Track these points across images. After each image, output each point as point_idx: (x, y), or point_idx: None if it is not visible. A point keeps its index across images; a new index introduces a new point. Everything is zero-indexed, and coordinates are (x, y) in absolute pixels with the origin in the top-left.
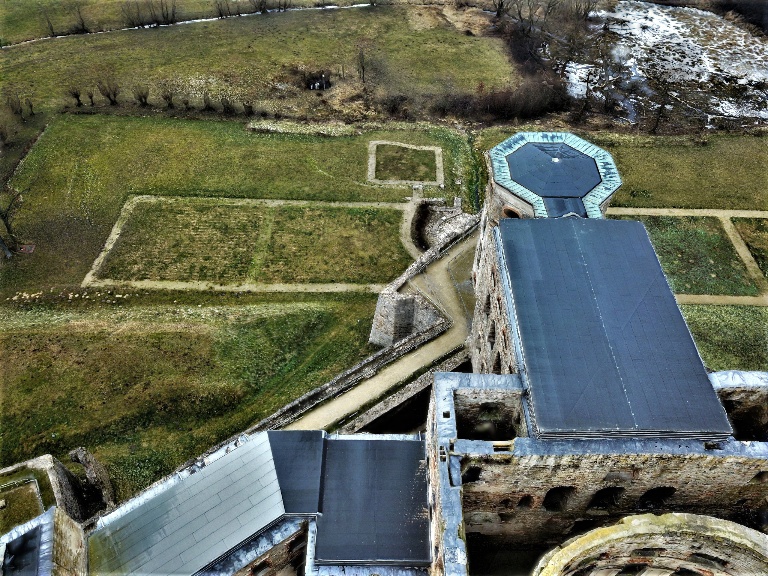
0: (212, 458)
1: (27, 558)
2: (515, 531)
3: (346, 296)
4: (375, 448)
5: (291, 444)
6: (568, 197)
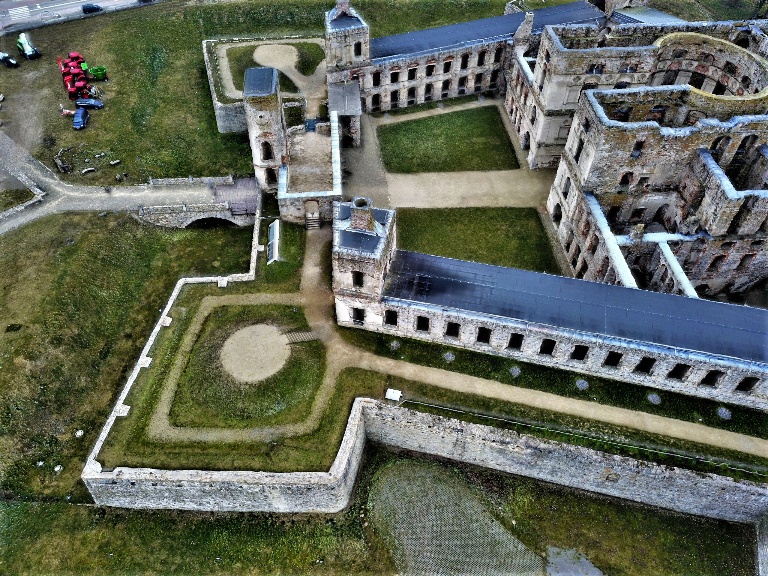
0: None
1: None
2: None
3: None
4: None
5: None
6: None
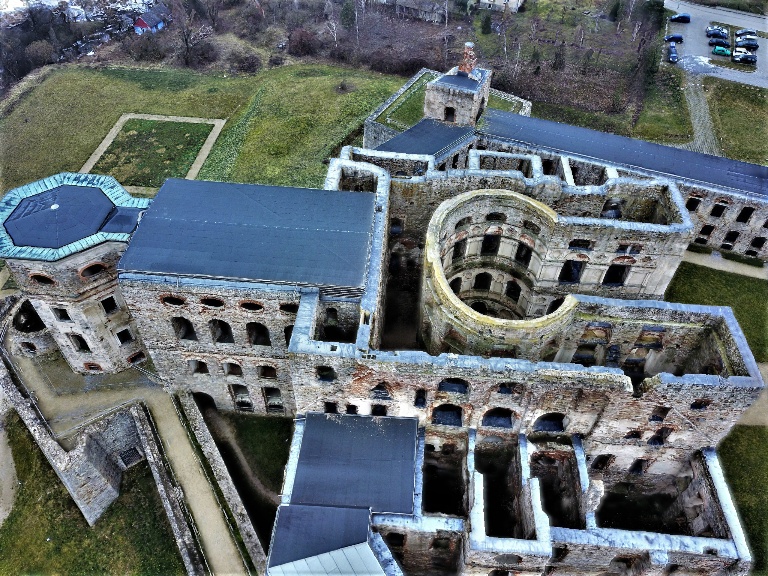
0: None
1: None
2: None
3: None
4: (308, 456)
5: (290, 539)
6: (113, 212)
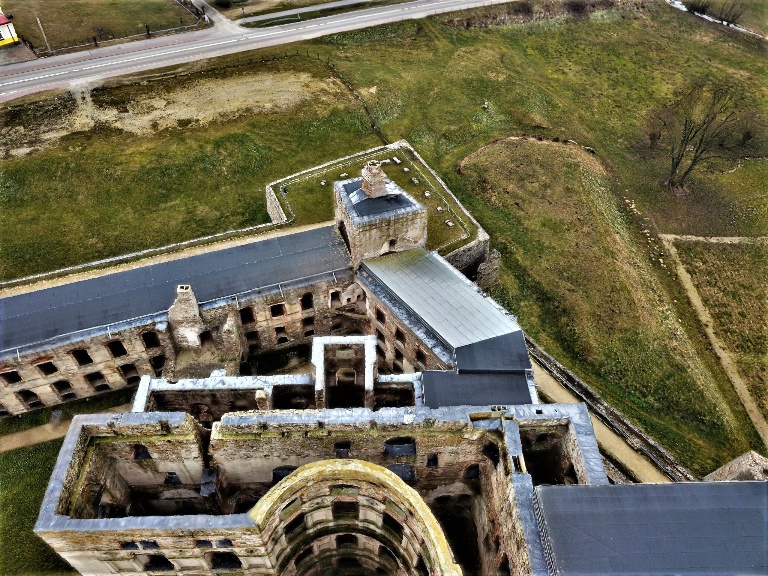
0: (491, 301)
1: (395, 203)
2: (484, 571)
3: (763, 454)
4: None
5: (513, 347)
6: None
